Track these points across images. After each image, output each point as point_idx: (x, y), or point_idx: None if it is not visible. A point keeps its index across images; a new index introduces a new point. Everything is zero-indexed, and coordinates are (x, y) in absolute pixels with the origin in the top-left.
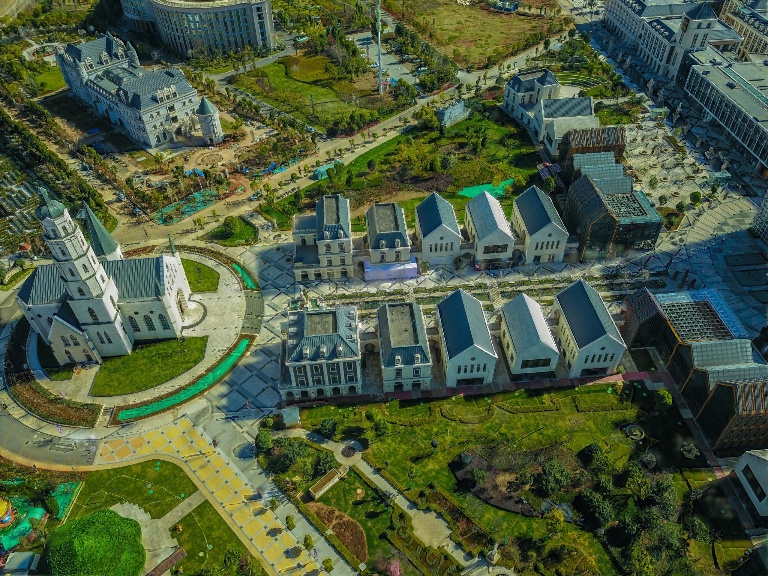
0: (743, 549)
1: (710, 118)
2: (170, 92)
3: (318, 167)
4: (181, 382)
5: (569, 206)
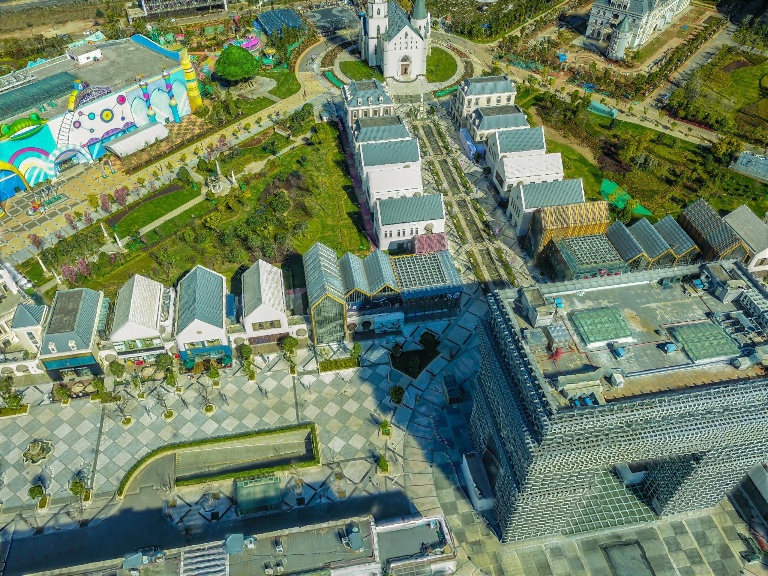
0: (230, 289)
1: None
2: (623, 3)
3: (600, 103)
4: None
5: None
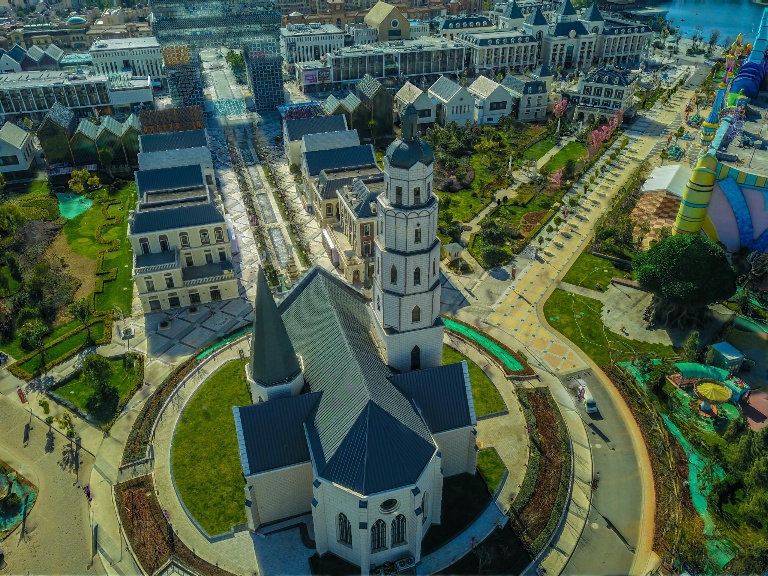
0: None
1: (2, 119)
2: None
3: None
4: None
5: None
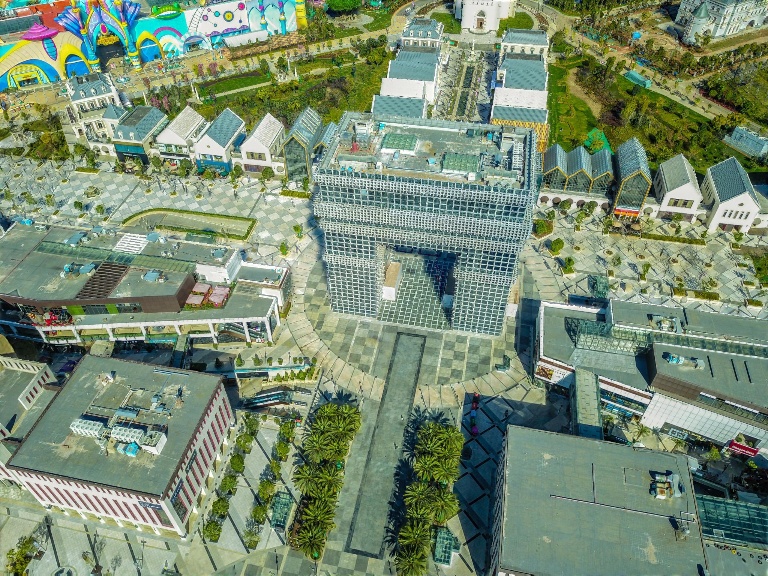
0: None
1: None
2: None
3: None
4: None
5: None
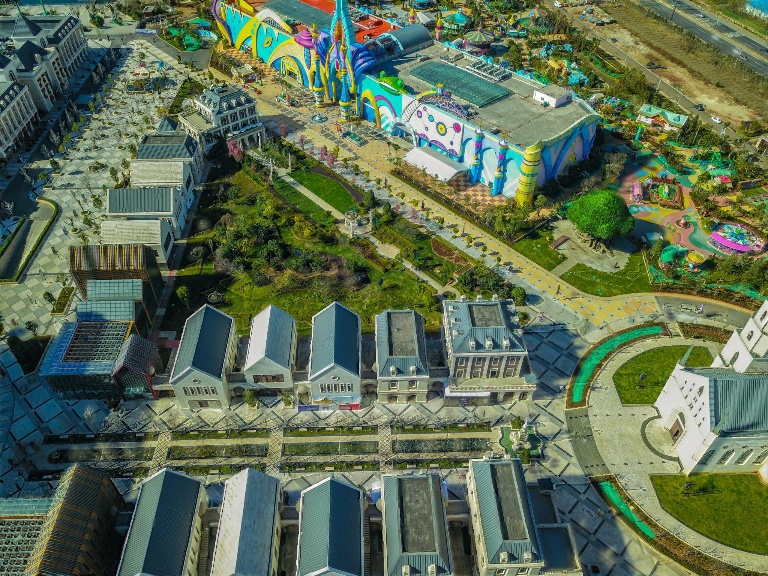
0: (196, 237)
1: None
2: None
3: None
4: (622, 356)
5: (92, 569)
